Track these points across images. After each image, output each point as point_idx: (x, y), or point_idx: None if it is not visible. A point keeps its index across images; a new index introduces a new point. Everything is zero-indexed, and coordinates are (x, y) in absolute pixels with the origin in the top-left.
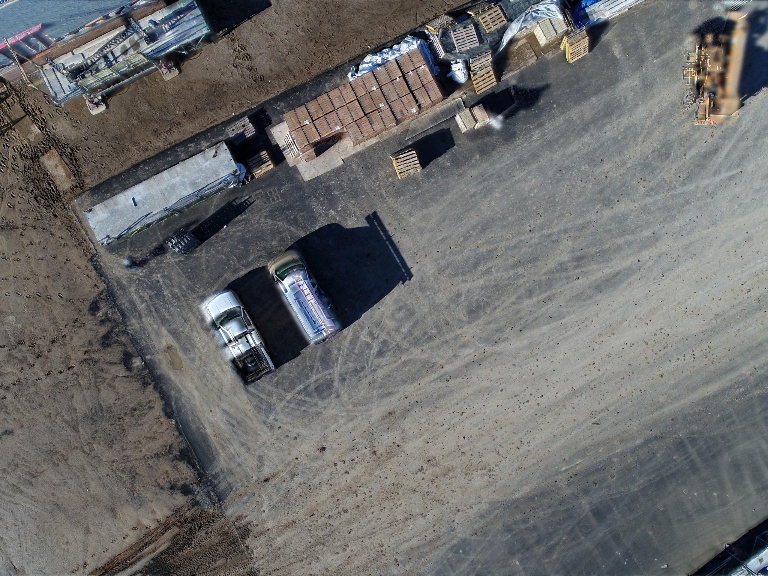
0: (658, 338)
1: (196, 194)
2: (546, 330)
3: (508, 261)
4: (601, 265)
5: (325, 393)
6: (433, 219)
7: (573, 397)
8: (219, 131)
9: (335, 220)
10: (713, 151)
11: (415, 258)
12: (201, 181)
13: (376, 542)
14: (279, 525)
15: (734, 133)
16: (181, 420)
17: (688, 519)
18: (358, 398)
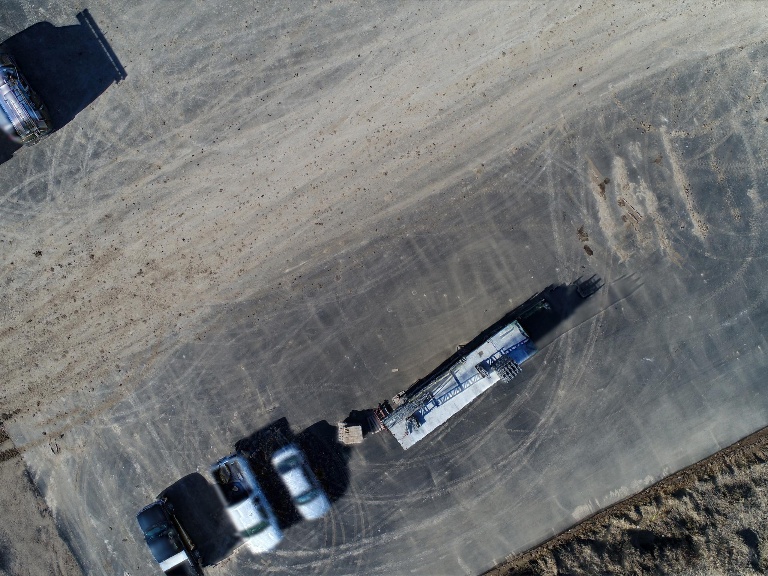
0: (381, 135)
1: None
2: (265, 128)
3: (225, 58)
4: (321, 61)
5: (39, 196)
6: (146, 16)
7: (295, 197)
8: None
9: (45, 18)
10: None
11: (129, 57)
12: None
13: (96, 348)
14: None
15: None
16: None
17: (418, 321)
18: (73, 201)
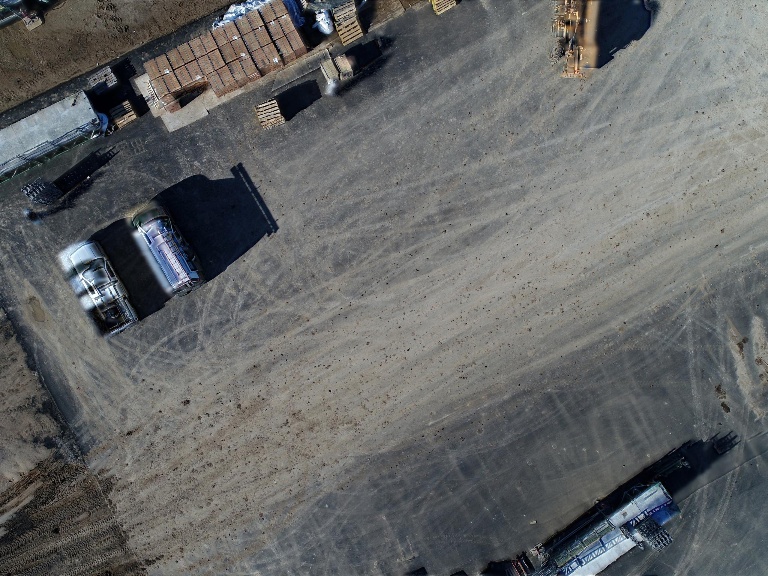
0: (526, 292)
1: (51, 142)
2: (413, 283)
3: (375, 214)
4: (469, 218)
5: (189, 346)
6: (299, 171)
7: (440, 351)
8: (83, 81)
9: (200, 171)
10: (582, 104)
11: (281, 210)
12: (60, 130)
13: (241, 496)
14: (142, 479)
15: (603, 86)
16: (43, 372)
17: (557, 475)
18: (223, 351)
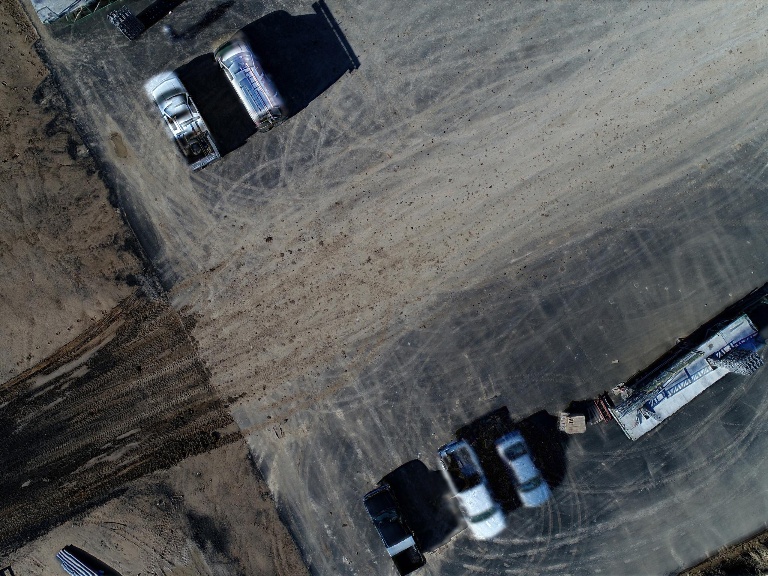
0: (608, 129)
1: None
2: (495, 120)
3: (457, 50)
4: (551, 54)
5: (271, 182)
6: (381, 7)
7: (522, 188)
8: None
9: (281, 7)
10: None
11: (362, 46)
12: None
13: (323, 333)
14: (225, 315)
15: None
16: (126, 208)
17: (639, 314)
18: (305, 187)
